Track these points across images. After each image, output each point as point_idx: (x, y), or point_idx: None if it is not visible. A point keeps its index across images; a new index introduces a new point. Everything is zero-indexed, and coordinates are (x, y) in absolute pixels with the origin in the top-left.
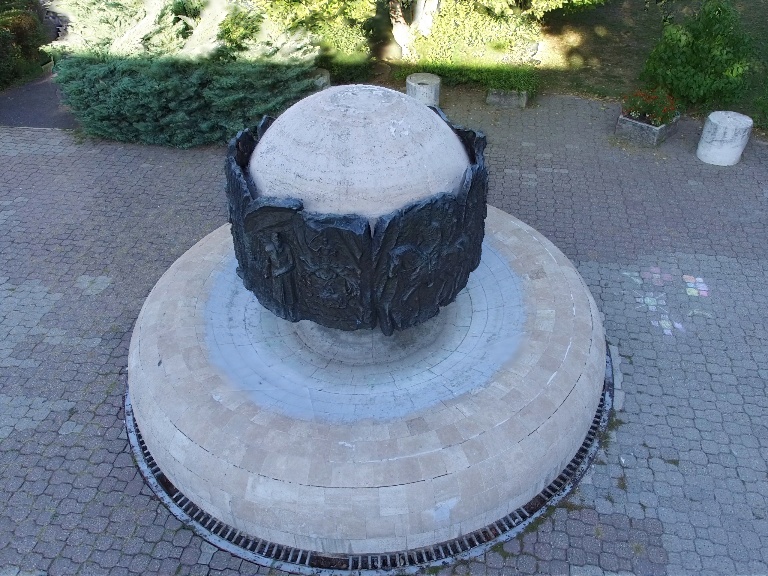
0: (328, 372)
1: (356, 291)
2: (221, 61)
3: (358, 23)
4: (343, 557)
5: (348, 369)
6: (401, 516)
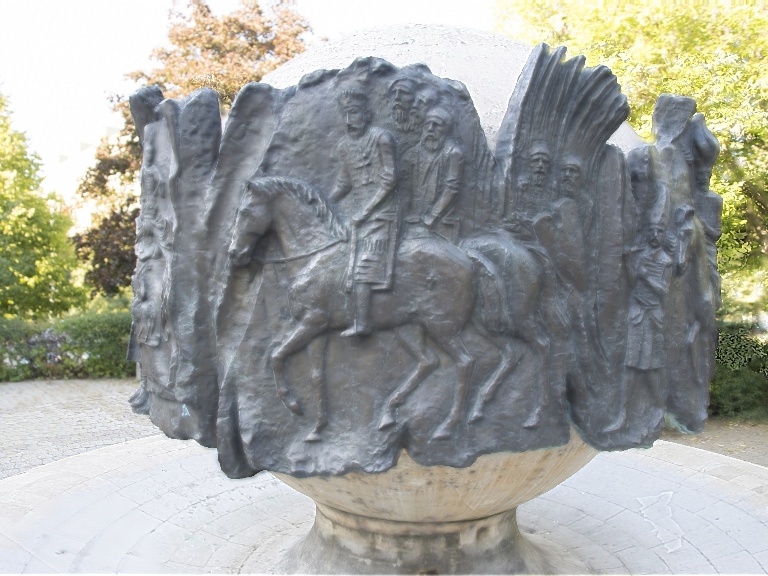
0: None
1: (168, 288)
2: None
3: (760, 337)
4: None
5: None
6: None
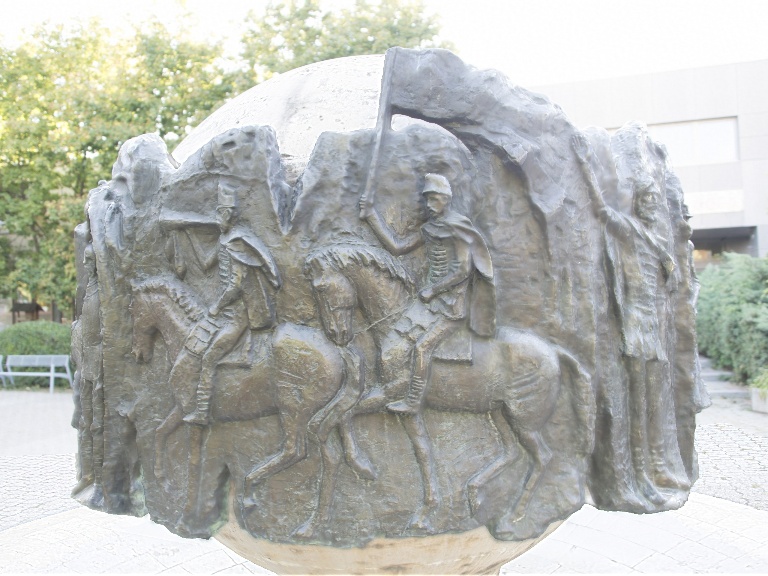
0: None
1: None
2: None
3: None
4: None
5: None
6: None
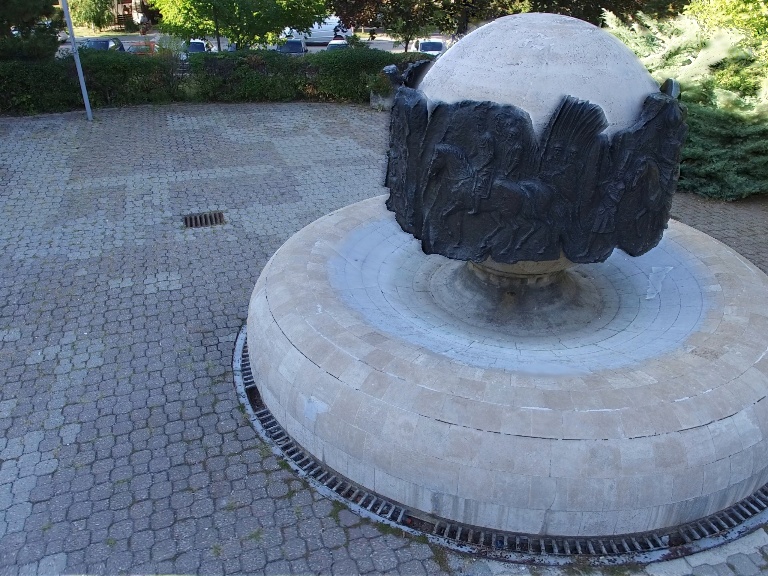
0: (412, 293)
1: None
2: (697, 104)
3: None
4: (266, 406)
5: (428, 302)
6: (288, 383)
